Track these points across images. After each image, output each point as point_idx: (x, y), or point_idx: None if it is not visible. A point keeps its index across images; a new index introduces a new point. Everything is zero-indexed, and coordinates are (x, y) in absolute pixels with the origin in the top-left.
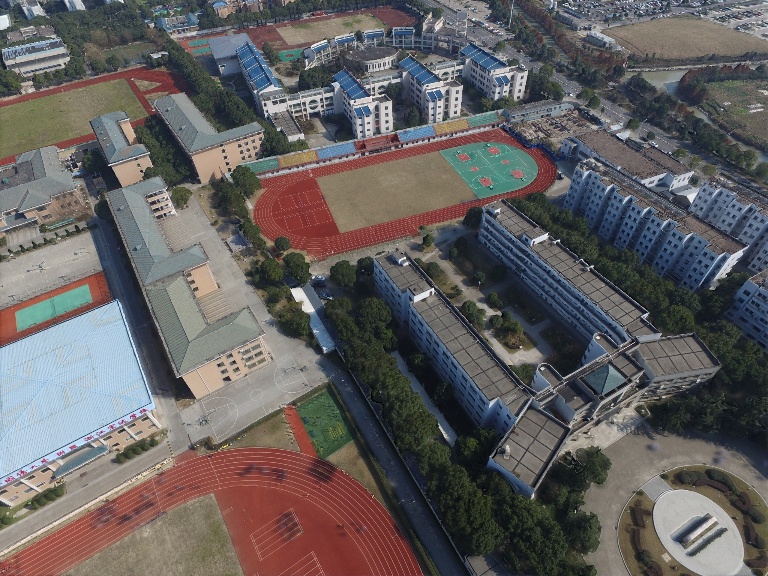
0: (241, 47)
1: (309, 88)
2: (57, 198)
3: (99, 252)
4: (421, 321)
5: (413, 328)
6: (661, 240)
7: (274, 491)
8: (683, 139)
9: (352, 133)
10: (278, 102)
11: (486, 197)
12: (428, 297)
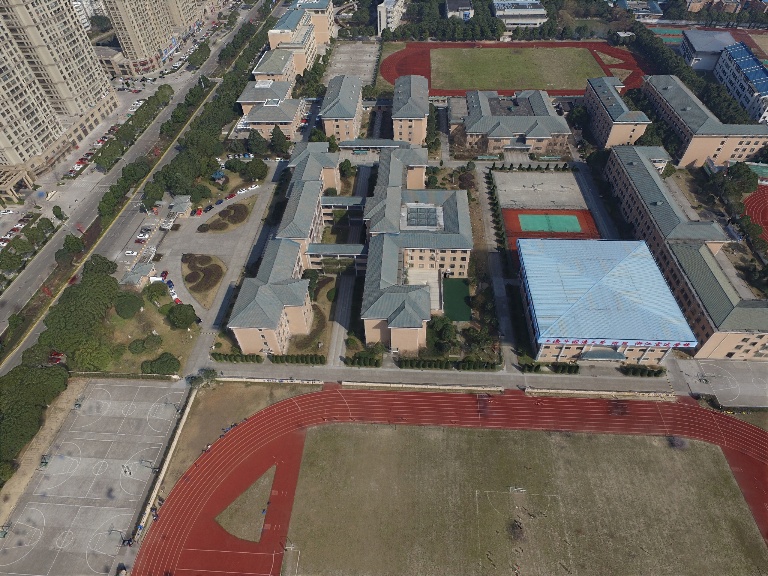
0: (733, 45)
1: None
2: (552, 136)
3: (583, 193)
4: None
5: None
6: None
7: None
8: None
9: None
10: None
11: None
12: None
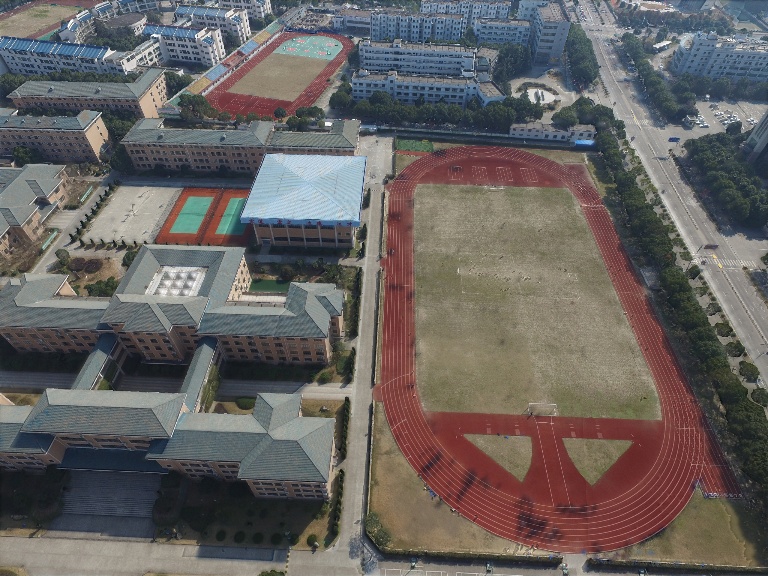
0: (2, 43)
1: (124, 50)
2: None
3: (157, 186)
4: (407, 85)
5: (399, 98)
6: (434, 29)
7: (435, 168)
8: (374, 6)
9: (202, 65)
10: (130, 59)
11: (334, 58)
12: (397, 77)
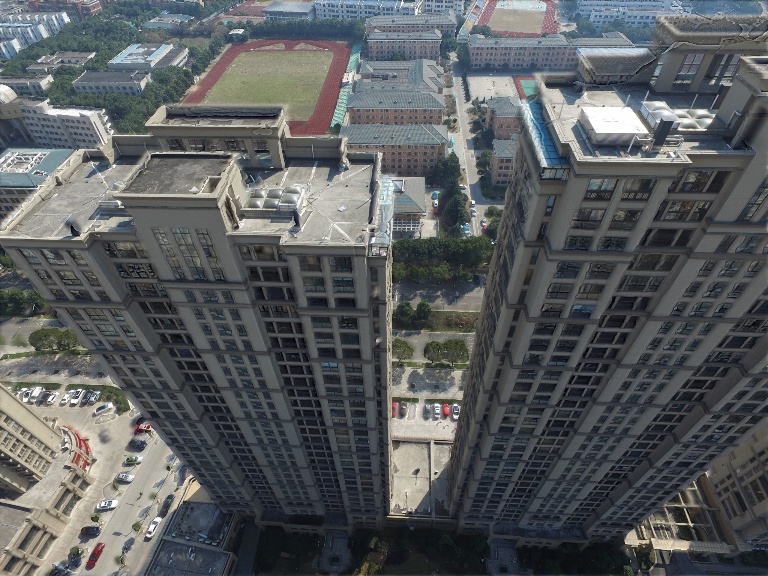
0: None
1: None
2: None
3: (493, 76)
4: (636, 15)
5: None
6: None
7: None
8: None
9: None
10: None
11: None
12: None
